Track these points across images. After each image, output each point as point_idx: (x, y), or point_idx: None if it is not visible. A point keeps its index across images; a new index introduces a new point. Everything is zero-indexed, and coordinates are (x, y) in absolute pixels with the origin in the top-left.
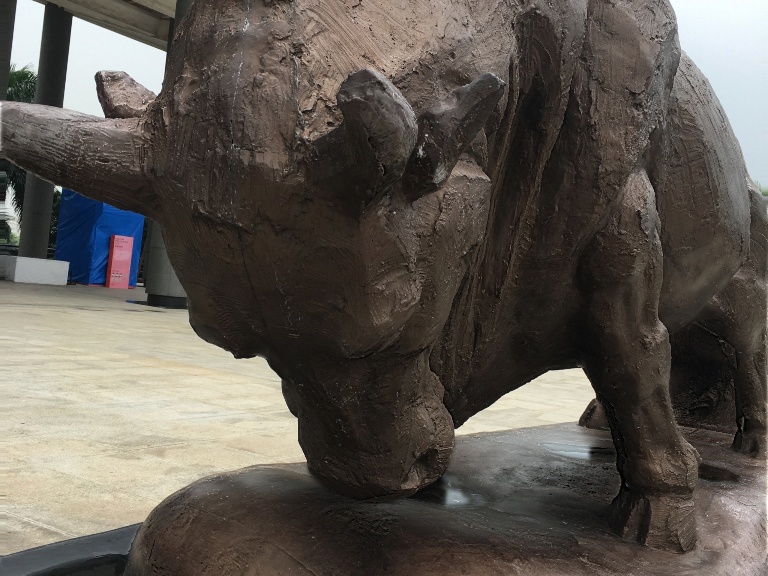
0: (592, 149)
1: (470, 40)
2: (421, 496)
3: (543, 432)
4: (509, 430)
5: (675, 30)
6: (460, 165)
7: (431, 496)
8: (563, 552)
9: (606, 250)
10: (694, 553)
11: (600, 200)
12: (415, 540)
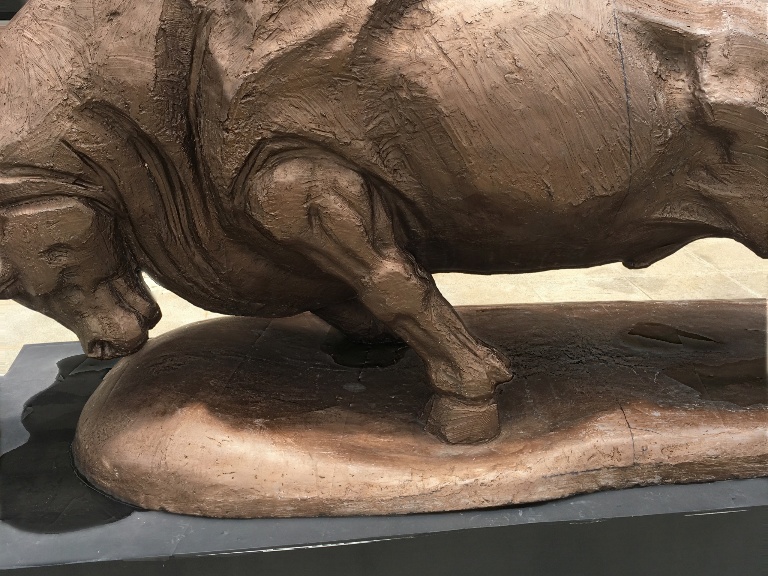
0: (205, 162)
1: (19, 142)
2: (350, 354)
3: (694, 310)
4: (659, 303)
5: (343, 33)
6: (33, 206)
7: (360, 355)
8: (251, 413)
9: (254, 224)
10: (469, 448)
11: (220, 195)
12: (159, 382)
